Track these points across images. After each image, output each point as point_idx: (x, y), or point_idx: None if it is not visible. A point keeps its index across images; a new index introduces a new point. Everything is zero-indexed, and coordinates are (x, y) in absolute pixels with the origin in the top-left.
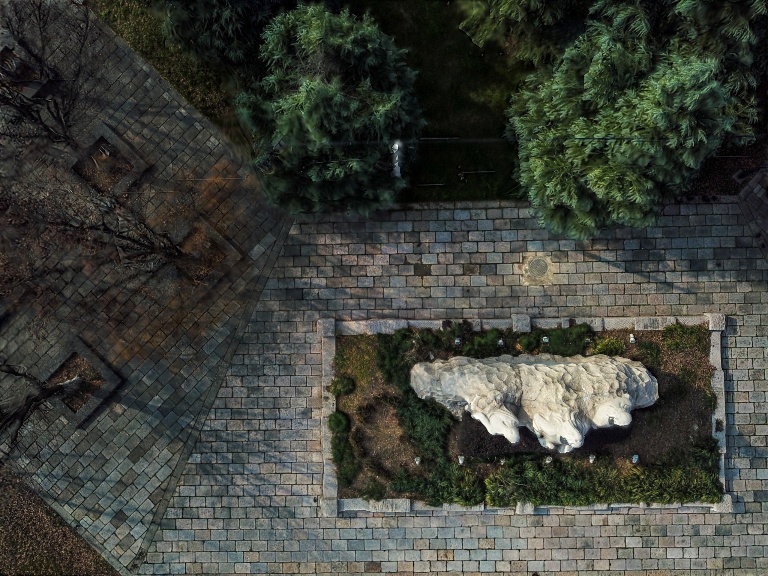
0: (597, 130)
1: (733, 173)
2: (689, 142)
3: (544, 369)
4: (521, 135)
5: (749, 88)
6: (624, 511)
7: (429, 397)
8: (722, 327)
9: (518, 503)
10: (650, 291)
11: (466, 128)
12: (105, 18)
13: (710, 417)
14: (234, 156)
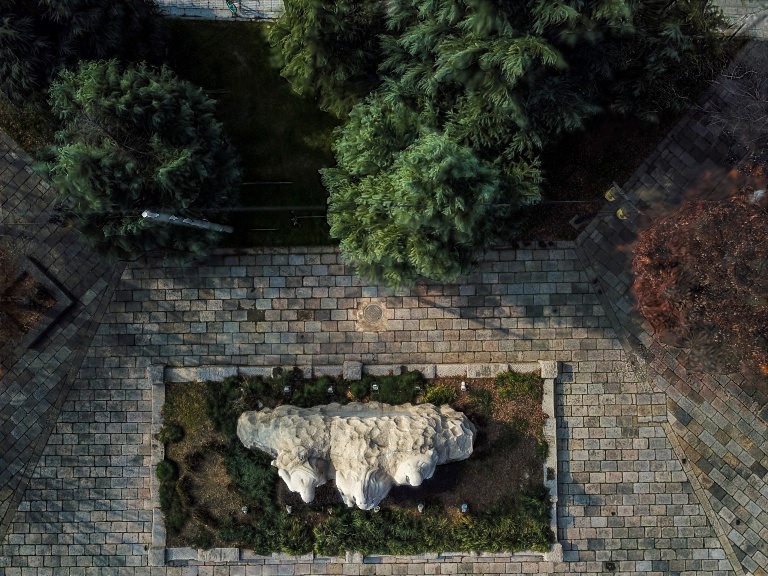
0: (376, 191)
1: (569, 218)
2: (446, 209)
3: (355, 423)
4: (327, 187)
5: (534, 147)
6: (457, 559)
7: (253, 447)
8: (554, 375)
9: (347, 553)
10: (485, 337)
11: (299, 172)
12: None
13: (542, 465)
14: None
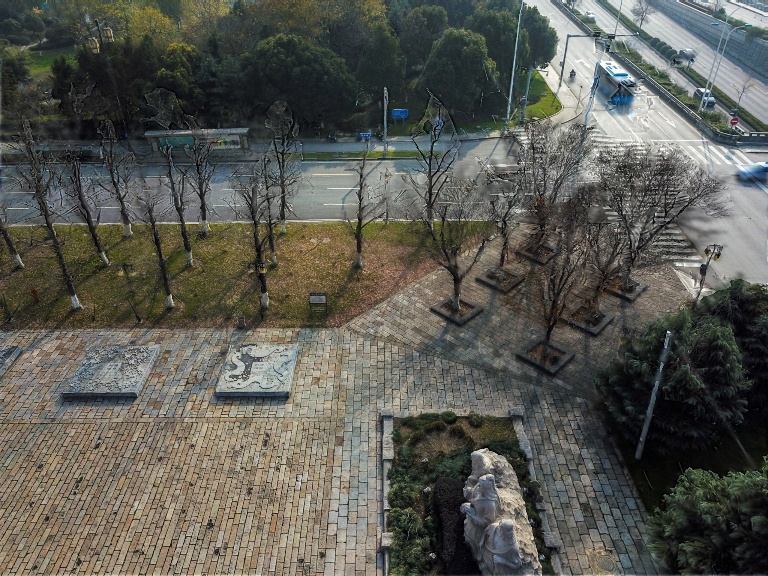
0: None
1: None
2: (767, 490)
3: None
4: None
5: None
6: None
7: None
8: None
9: (392, 533)
10: None
11: None
12: None
13: None
14: None
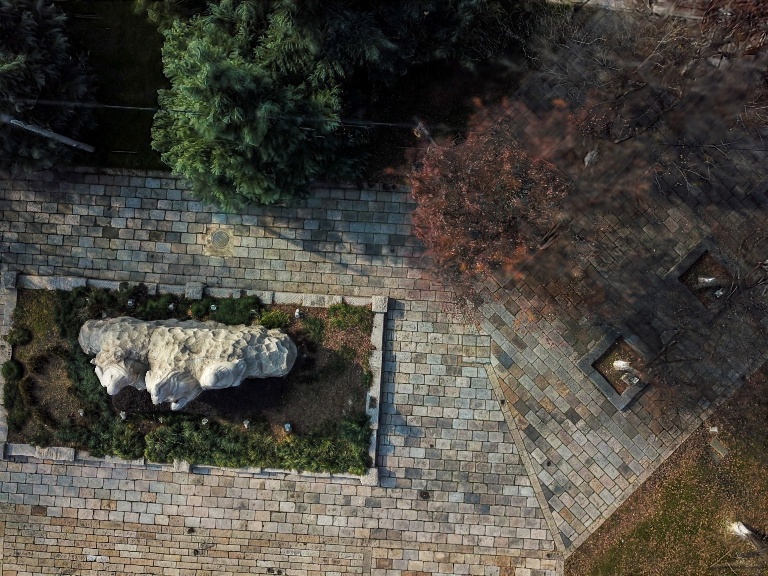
0: (182, 103)
1: None
2: (226, 118)
3: (176, 331)
4: None
5: (336, 76)
6: (281, 477)
7: (91, 352)
8: (383, 309)
9: (174, 460)
10: (325, 270)
11: None
12: None
13: (365, 394)
14: None
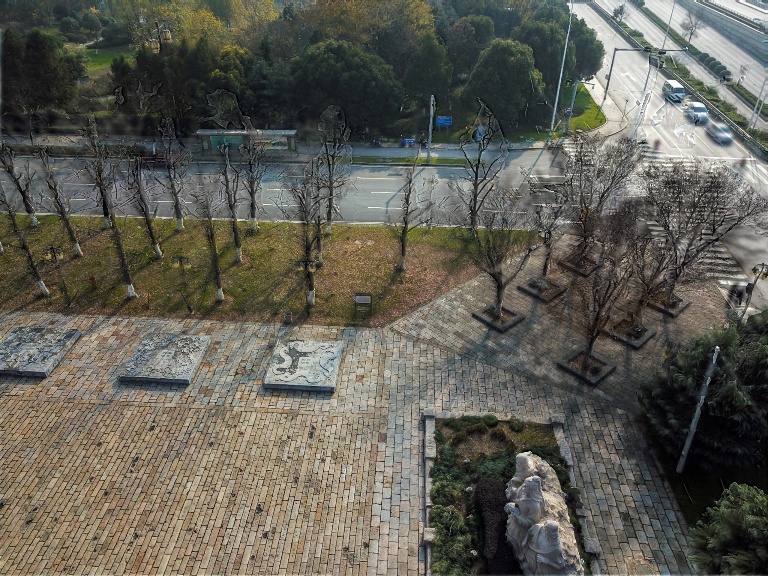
0: None
1: None
2: None
3: None
4: None
5: None
6: None
7: None
8: None
9: (434, 528)
10: None
11: None
12: None
13: None
14: None
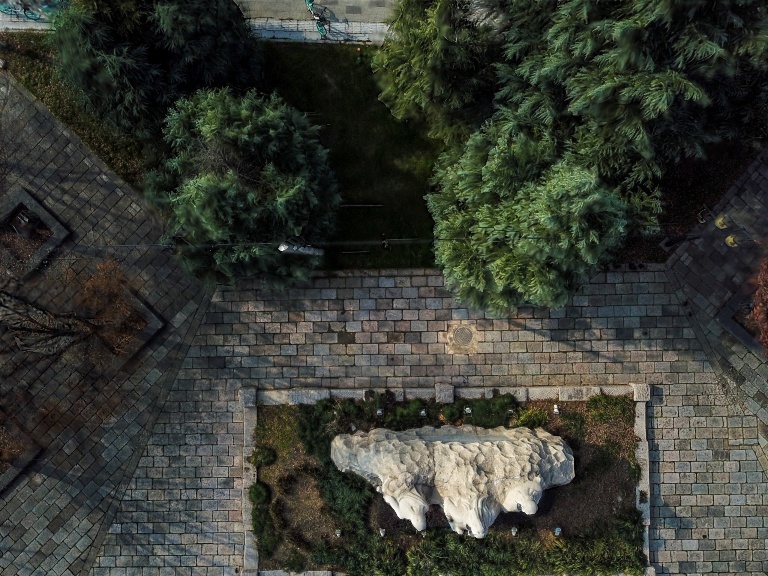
0: (498, 221)
1: (660, 241)
2: (581, 243)
3: (458, 448)
4: (433, 214)
5: (653, 177)
6: None
7: (349, 470)
8: (646, 398)
9: (440, 575)
10: (576, 360)
11: (390, 195)
12: (25, 82)
13: (634, 489)
14: (156, 222)
